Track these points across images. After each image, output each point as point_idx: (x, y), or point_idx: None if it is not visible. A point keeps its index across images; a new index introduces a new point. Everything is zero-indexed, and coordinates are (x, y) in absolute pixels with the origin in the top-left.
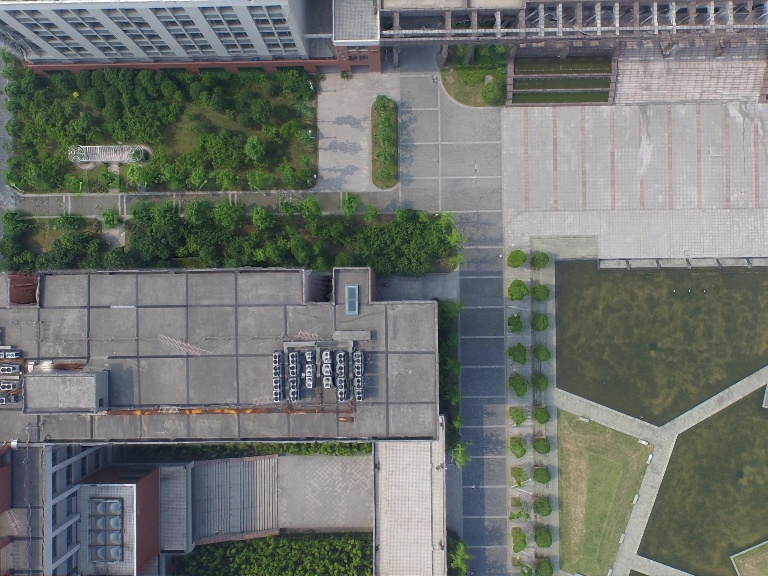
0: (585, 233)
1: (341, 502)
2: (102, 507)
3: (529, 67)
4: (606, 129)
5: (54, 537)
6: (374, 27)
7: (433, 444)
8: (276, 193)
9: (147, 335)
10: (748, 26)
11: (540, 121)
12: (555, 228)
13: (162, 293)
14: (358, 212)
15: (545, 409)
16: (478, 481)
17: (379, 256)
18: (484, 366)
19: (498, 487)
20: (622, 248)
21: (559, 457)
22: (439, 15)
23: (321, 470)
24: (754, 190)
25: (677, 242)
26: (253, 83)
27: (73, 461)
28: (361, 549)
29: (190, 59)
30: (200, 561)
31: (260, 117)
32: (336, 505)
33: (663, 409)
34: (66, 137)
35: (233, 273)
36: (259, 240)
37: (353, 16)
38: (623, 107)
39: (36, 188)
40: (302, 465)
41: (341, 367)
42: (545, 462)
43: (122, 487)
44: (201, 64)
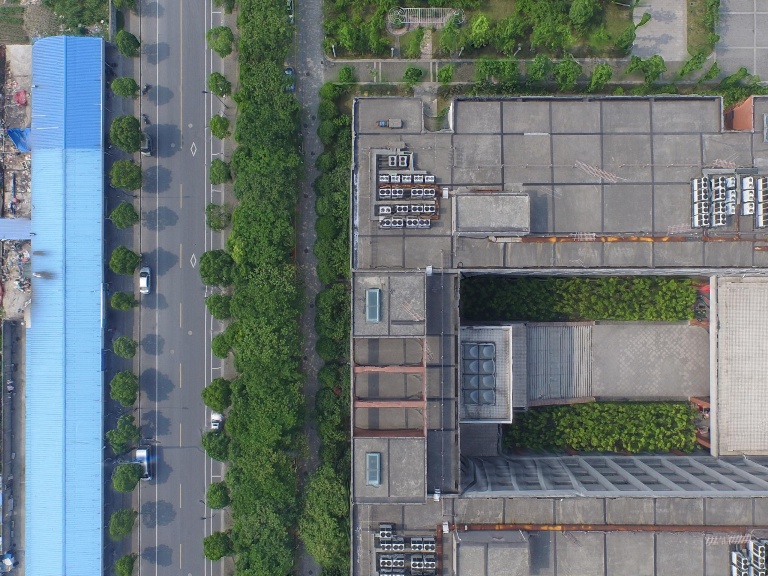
0: None
1: (655, 371)
2: (475, 350)
3: None
4: None
5: None
6: None
7: None
8: (590, 61)
9: (562, 162)
10: None
11: None
12: None
13: (576, 120)
14: (672, 81)
15: None
16: None
17: None
18: None
19: None
20: None
21: None
22: None
23: (635, 339)
24: None
25: None
26: None
27: None
28: (687, 413)
29: None
30: (524, 425)
31: None
32: (650, 374)
33: None
34: None
35: (648, 101)
36: None
37: None
38: None
39: (349, 53)
40: (616, 334)
41: None
42: None
43: (493, 331)
44: None
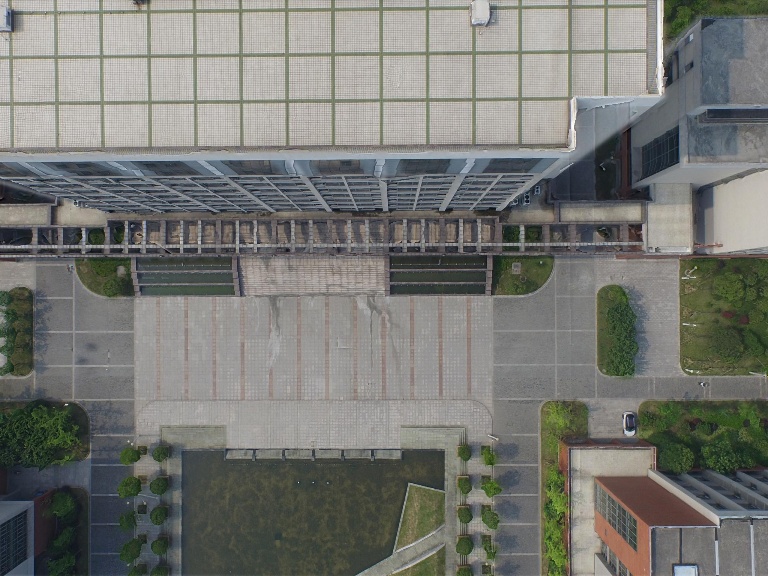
0: (214, 423)
1: None
2: None
3: (152, 263)
4: (236, 320)
5: None
6: None
7: None
8: None
9: None
10: (327, 245)
11: (172, 311)
12: (185, 417)
13: None
14: None
15: None
16: None
17: (3, 448)
18: (114, 553)
19: None
20: (250, 438)
21: None
22: None
23: None
24: (381, 382)
25: (304, 433)
26: None
27: None
28: None
29: None
30: None
31: None
32: None
33: None
34: None
35: None
36: None
37: None
38: (253, 298)
39: None
40: None
41: None
42: None
43: None
44: None
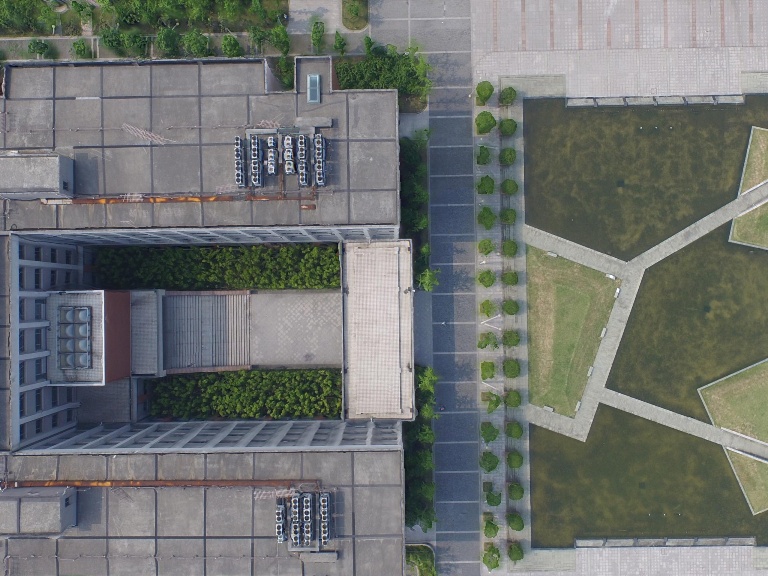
0: (553, 72)
1: (312, 339)
2: (71, 315)
3: None
4: None
5: (21, 331)
6: None
7: (401, 268)
8: (247, 35)
9: (112, 125)
10: None
11: None
12: (523, 68)
13: (126, 84)
14: None
15: None
16: (448, 318)
17: None
18: (453, 204)
19: (468, 323)
20: (589, 87)
21: (528, 292)
22: None
23: (293, 308)
24: (720, 29)
25: (644, 81)
26: None
27: (42, 266)
28: (331, 379)
29: None
30: (172, 392)
31: None
32: (307, 342)
33: (630, 245)
34: None
35: (196, 64)
36: None
37: None
38: None
39: (10, 31)
40: (274, 303)
41: (302, 148)
42: (514, 297)
43: (91, 296)
44: None
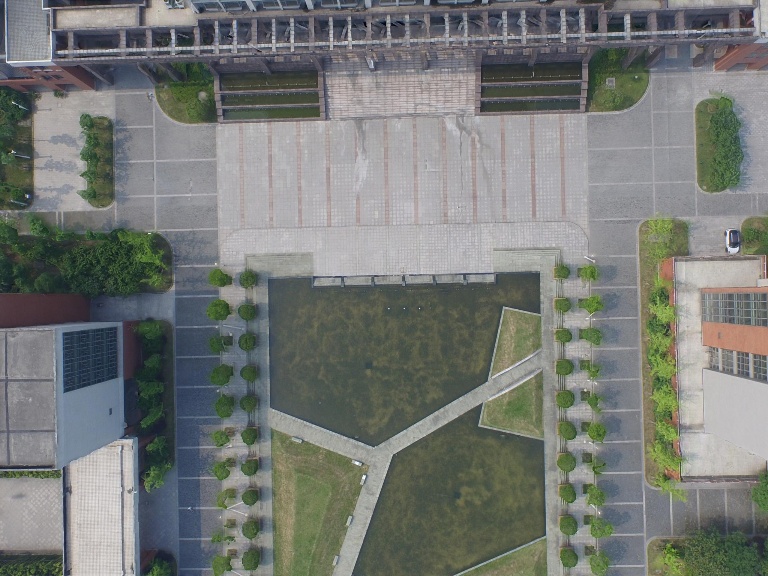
0: (300, 250)
1: (57, 524)
2: None
3: (236, 83)
4: (321, 144)
5: None
6: (48, 47)
7: (124, 467)
8: None
9: None
10: (425, 40)
11: (255, 137)
12: (270, 246)
13: None
14: (74, 232)
15: (258, 430)
16: (194, 502)
17: (86, 276)
18: (200, 386)
19: (214, 508)
20: (337, 265)
21: (273, 478)
22: (116, 34)
23: (37, 492)
24: (472, 205)
25: (393, 259)
26: None
27: None
28: None
29: None
30: None
31: None
32: (52, 527)
33: (379, 429)
34: None
35: None
36: None
37: (24, 36)
38: (338, 122)
39: None
40: (19, 487)
41: None
42: (259, 483)
43: None
44: None
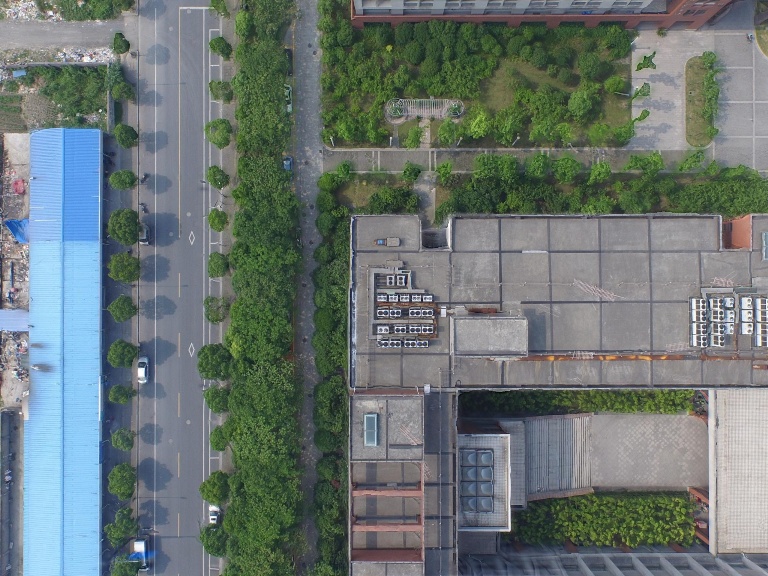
0: None
1: (653, 461)
2: (474, 458)
3: None
4: None
5: None
6: None
7: None
8: (589, 150)
9: (560, 280)
10: None
11: None
12: None
13: (574, 238)
14: (671, 170)
15: None
16: None
17: None
18: None
19: None
20: None
21: None
22: None
23: (633, 429)
24: None
25: None
26: (567, 39)
27: None
28: (685, 507)
29: (522, 11)
30: (522, 518)
31: (591, 71)
32: (648, 464)
33: None
34: (383, 90)
35: (646, 219)
36: (582, 196)
37: None
38: None
39: (347, 142)
40: (614, 424)
41: None
42: None
43: (492, 438)
44: (531, 17)
